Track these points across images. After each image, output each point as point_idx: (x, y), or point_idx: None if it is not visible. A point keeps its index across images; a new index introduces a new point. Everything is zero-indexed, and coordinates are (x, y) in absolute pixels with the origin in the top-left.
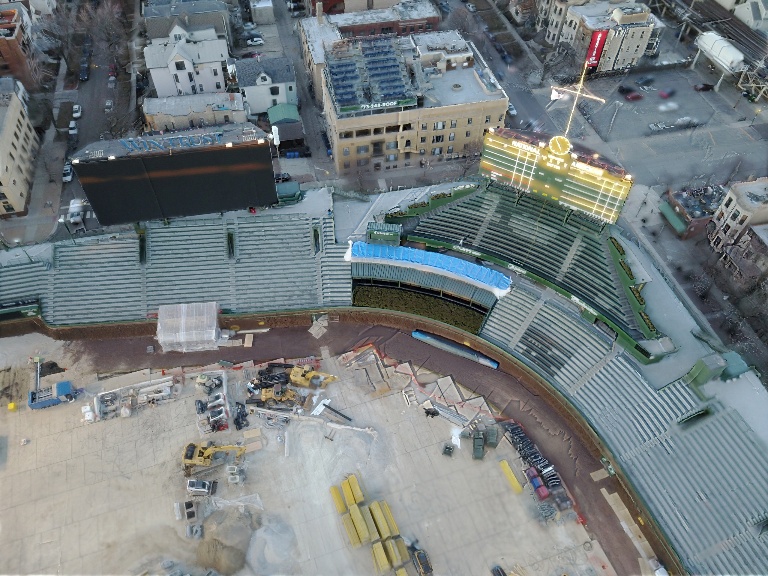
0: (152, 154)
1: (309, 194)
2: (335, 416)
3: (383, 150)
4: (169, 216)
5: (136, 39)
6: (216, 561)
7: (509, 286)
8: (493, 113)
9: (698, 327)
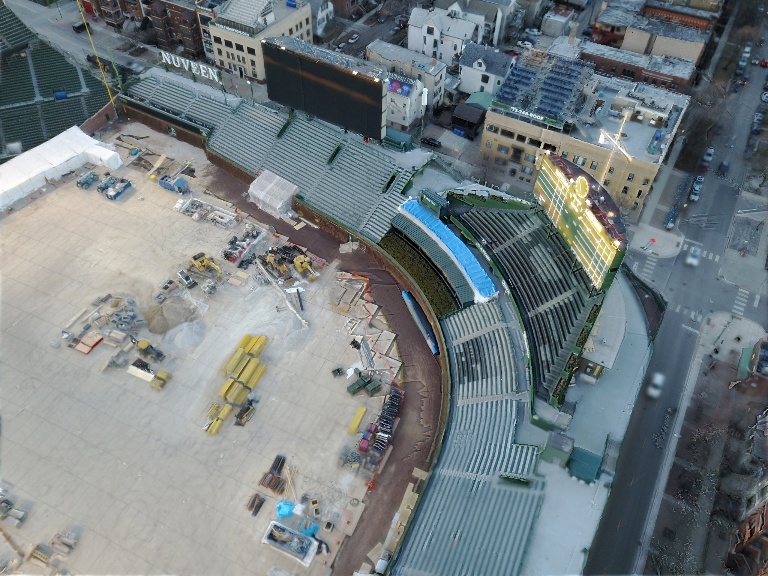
0: (307, 57)
1: (415, 151)
2: (296, 301)
3: (521, 159)
4: (308, 113)
5: (424, 3)
6: (152, 319)
7: (490, 297)
8: (638, 173)
9: (621, 437)
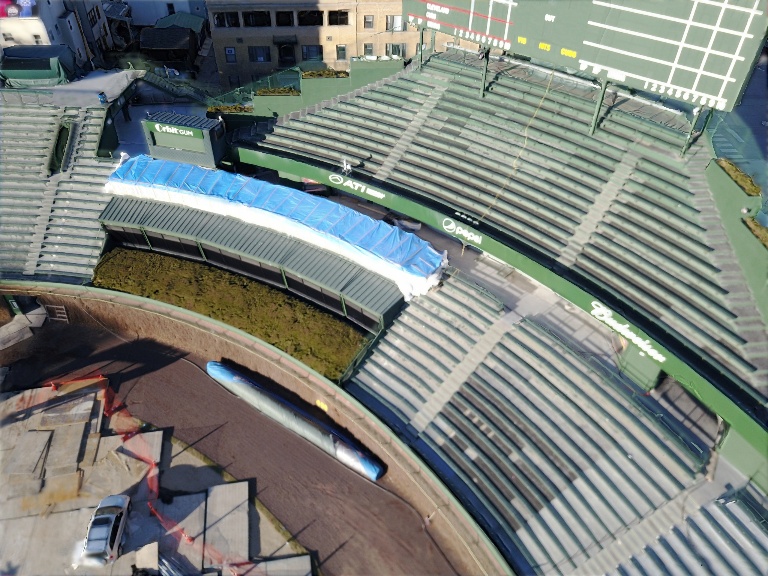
0: None
1: (92, 75)
2: None
3: (297, 61)
4: None
5: None
6: None
7: (437, 270)
8: None
9: None
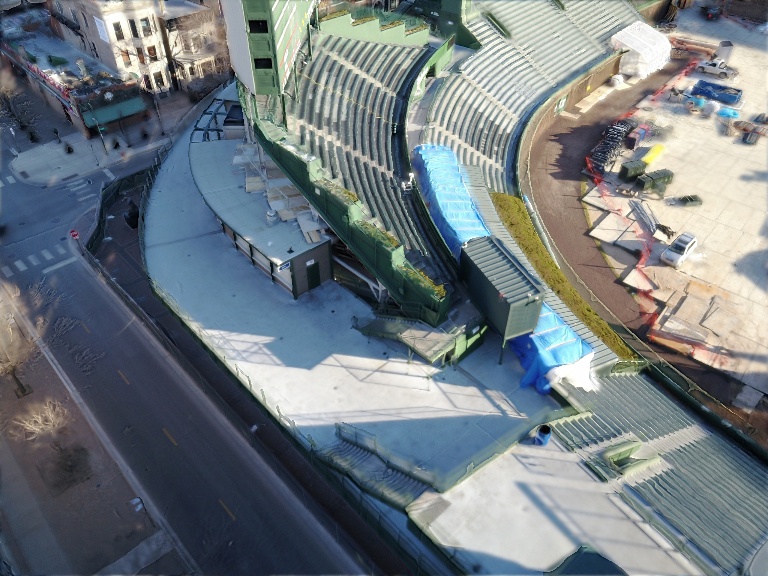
0: None
1: (509, 571)
2: None
3: None
4: None
5: None
6: None
7: None
8: None
9: None
